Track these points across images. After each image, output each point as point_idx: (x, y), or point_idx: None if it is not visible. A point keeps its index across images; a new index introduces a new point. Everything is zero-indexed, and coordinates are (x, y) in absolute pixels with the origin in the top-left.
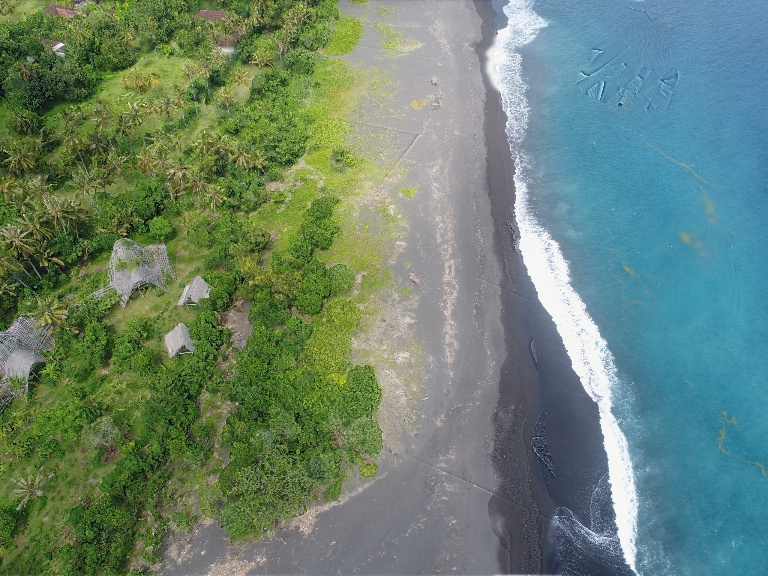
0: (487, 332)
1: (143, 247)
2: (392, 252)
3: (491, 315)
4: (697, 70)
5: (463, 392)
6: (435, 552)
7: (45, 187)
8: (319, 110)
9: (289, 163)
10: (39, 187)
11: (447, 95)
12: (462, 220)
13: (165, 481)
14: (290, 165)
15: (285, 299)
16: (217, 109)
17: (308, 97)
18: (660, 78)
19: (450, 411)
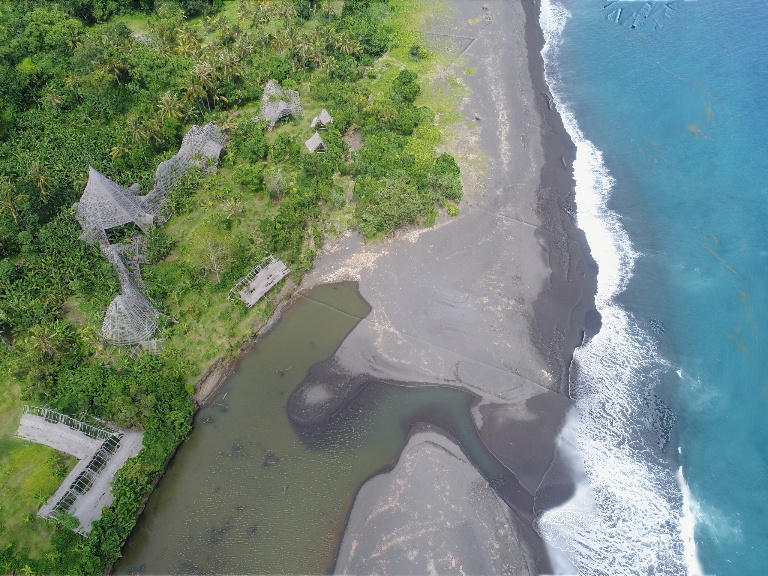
0: (531, 149)
1: (284, 90)
2: (460, 104)
3: (533, 141)
4: (696, 2)
5: (515, 178)
6: (499, 251)
7: (216, 47)
8: (396, 24)
9: (377, 55)
10: (212, 47)
11: (496, 16)
12: (510, 89)
13: (316, 215)
14: (378, 56)
15: (388, 122)
16: (320, 18)
17: (386, 17)
18: (665, 3)
19: (506, 187)
